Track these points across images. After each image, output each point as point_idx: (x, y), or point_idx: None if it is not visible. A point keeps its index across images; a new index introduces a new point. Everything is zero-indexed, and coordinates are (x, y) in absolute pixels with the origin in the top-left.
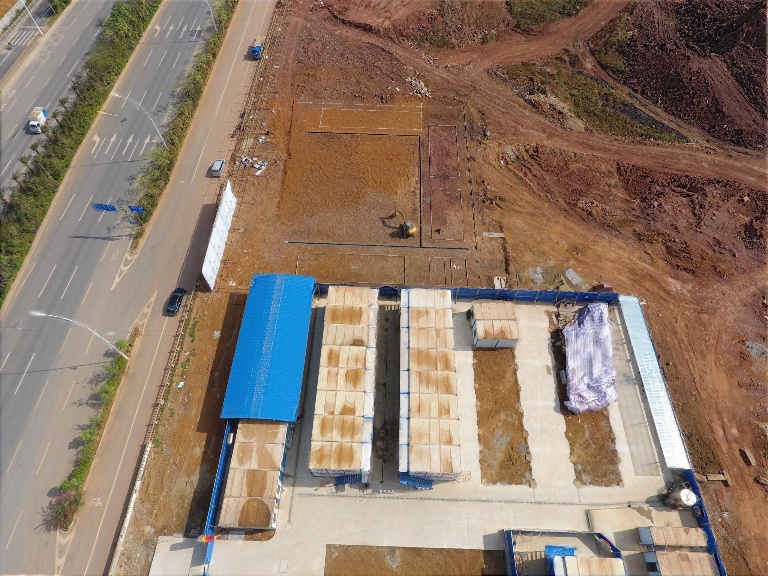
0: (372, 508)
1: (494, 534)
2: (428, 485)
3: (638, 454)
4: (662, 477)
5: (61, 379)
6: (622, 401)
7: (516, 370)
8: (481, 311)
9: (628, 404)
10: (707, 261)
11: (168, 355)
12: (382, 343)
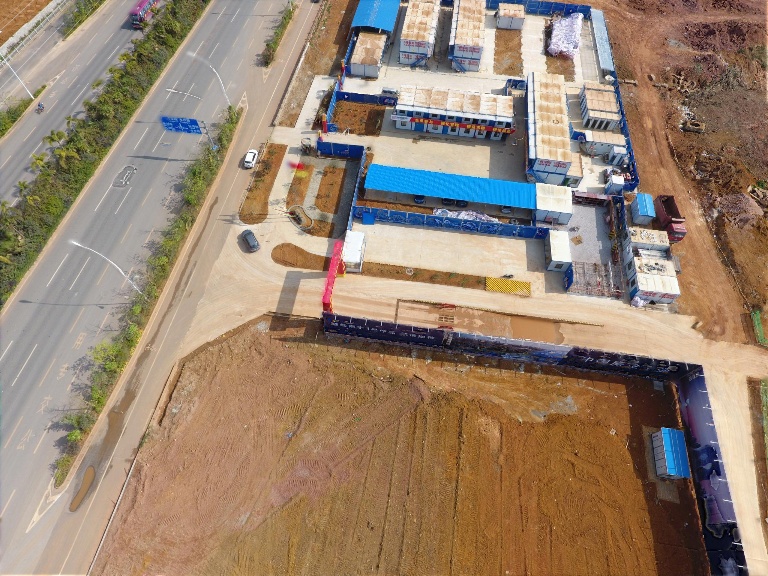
0: (431, 76)
1: (497, 89)
2: (463, 69)
3: (587, 73)
4: (599, 82)
5: (256, 19)
6: (583, 54)
7: (521, 38)
8: (503, 6)
9: (586, 56)
10: (654, 6)
11: (315, 17)
12: (441, 22)
